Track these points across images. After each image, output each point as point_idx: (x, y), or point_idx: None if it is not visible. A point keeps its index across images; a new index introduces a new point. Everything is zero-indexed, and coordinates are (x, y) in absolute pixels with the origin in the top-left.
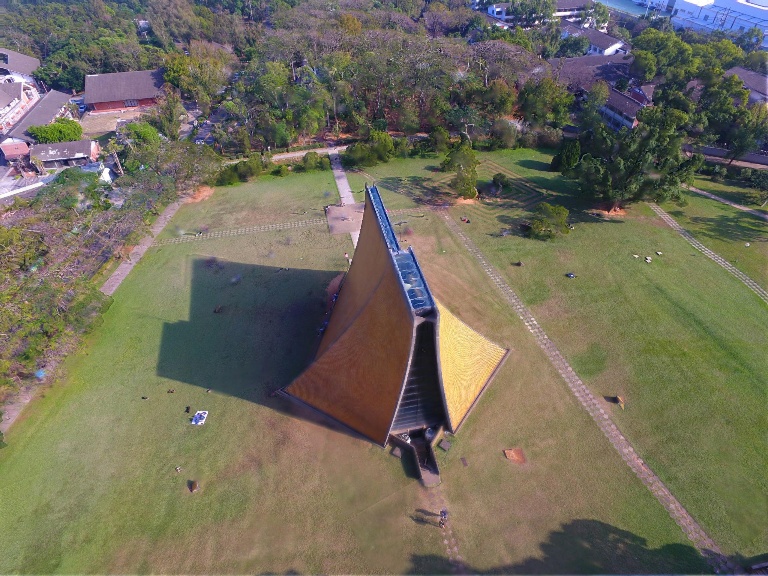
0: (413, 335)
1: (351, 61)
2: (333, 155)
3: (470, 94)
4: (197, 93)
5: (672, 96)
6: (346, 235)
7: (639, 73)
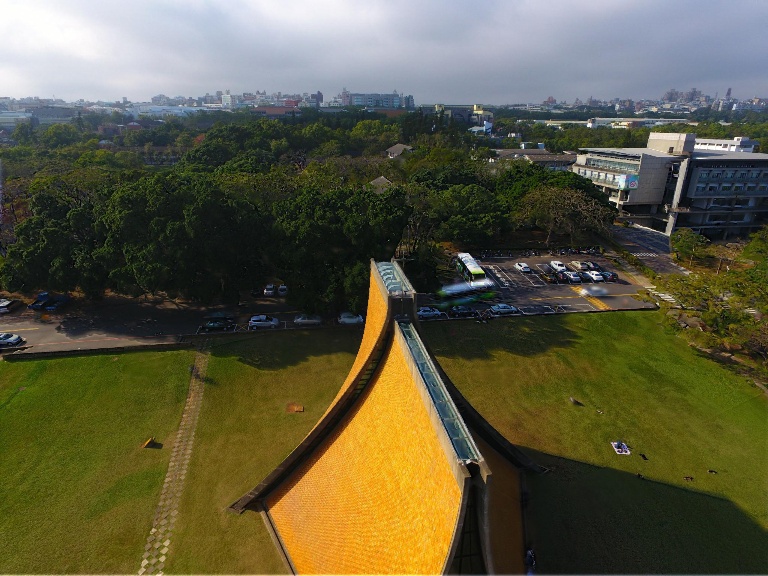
0: None
1: None
2: None
3: None
4: None
5: None
6: None
7: None
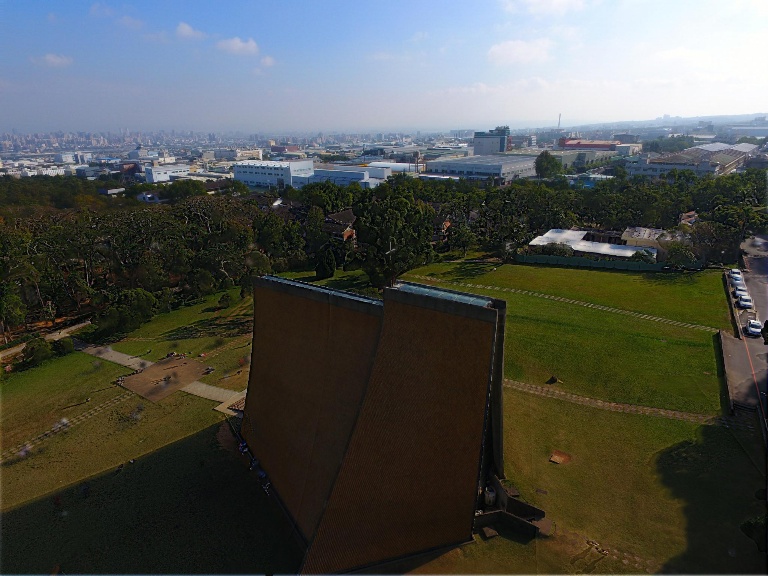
0: (495, 336)
1: (34, 237)
2: None
3: (205, 239)
4: None
5: (370, 206)
6: (177, 393)
7: None
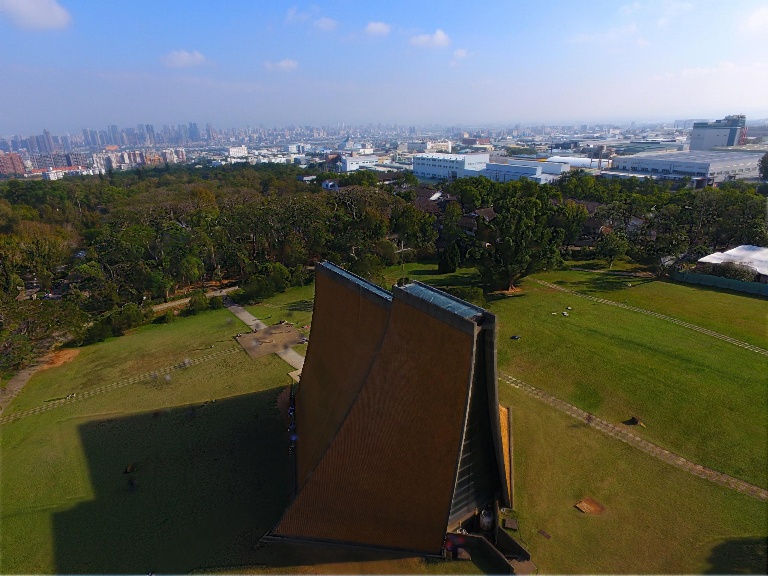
0: (473, 350)
1: (221, 214)
2: (221, 296)
3: (346, 225)
4: (35, 266)
5: None
6: (272, 355)
7: (469, 203)
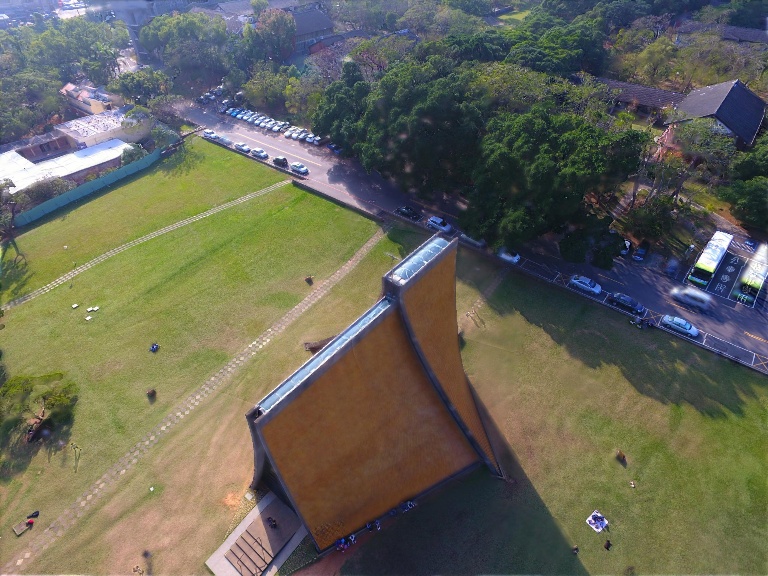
0: None
1: None
2: None
3: None
4: None
5: None
6: None
7: None
